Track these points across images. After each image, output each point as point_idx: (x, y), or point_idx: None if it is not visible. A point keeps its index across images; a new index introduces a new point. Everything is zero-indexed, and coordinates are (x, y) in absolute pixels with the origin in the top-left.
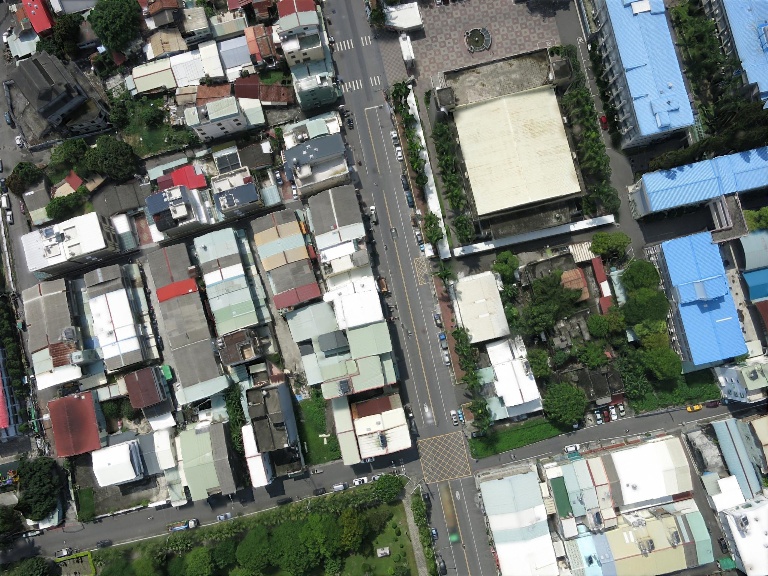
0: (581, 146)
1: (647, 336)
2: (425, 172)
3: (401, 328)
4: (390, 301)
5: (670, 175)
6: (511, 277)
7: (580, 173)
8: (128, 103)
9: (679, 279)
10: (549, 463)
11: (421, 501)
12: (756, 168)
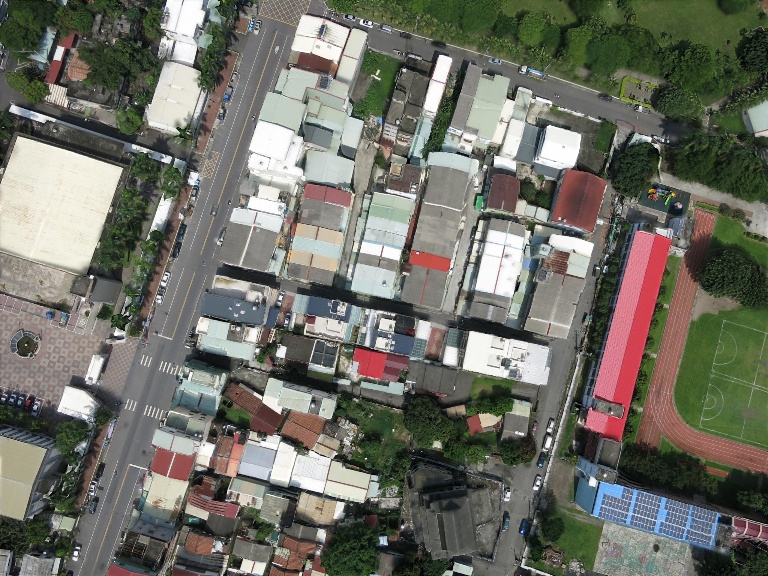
0: None
1: None
2: None
3: None
4: None
5: None
6: None
7: (8, 153)
8: (386, 471)
9: None
10: None
11: None
12: None
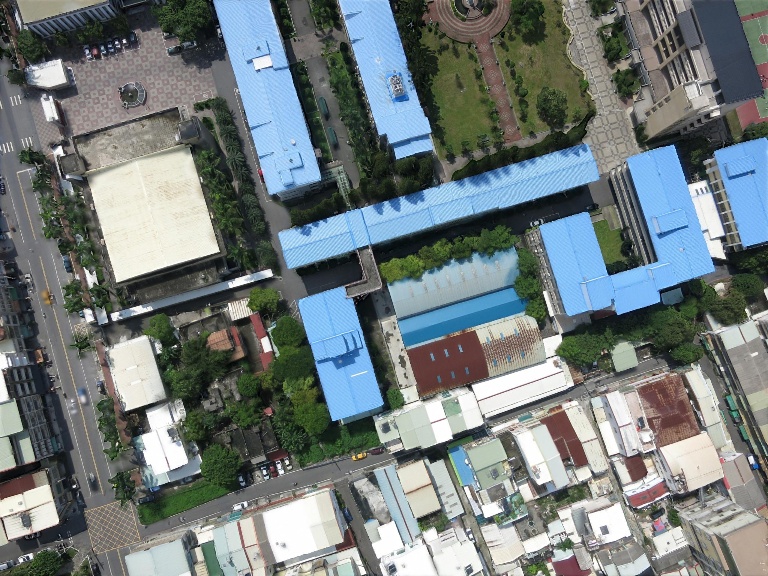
0: (212, 207)
1: (293, 393)
2: (78, 236)
3: (63, 398)
4: (51, 371)
5: (305, 231)
6: (173, 338)
7: (220, 233)
8: None
9: (315, 336)
10: (207, 526)
11: (80, 575)
12: (388, 220)
